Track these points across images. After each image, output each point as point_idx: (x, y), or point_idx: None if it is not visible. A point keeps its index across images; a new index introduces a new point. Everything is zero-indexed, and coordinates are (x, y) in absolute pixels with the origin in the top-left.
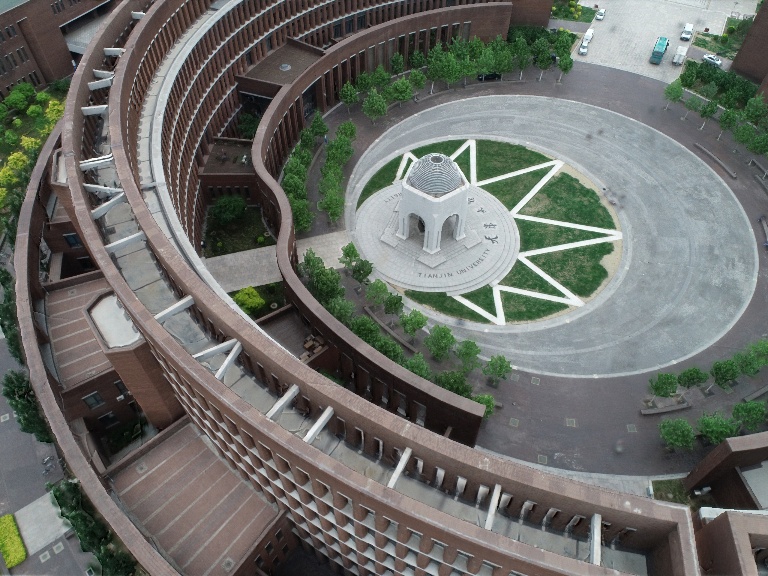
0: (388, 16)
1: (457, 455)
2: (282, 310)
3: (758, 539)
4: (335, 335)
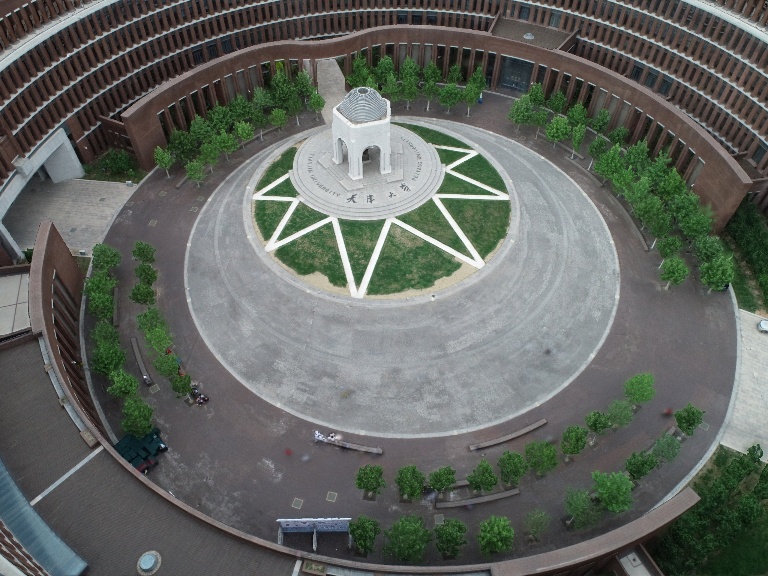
0: (695, 107)
1: None
2: None
3: None
4: None
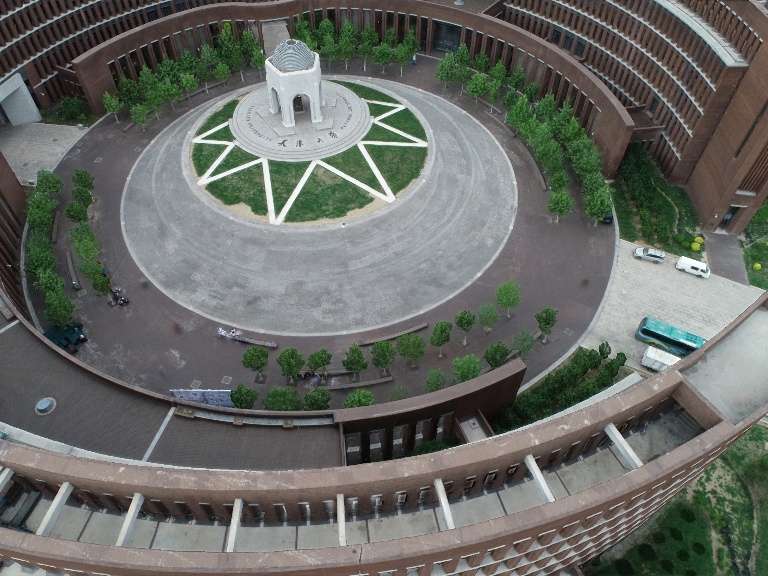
0: (605, 66)
1: None
2: None
3: None
4: None
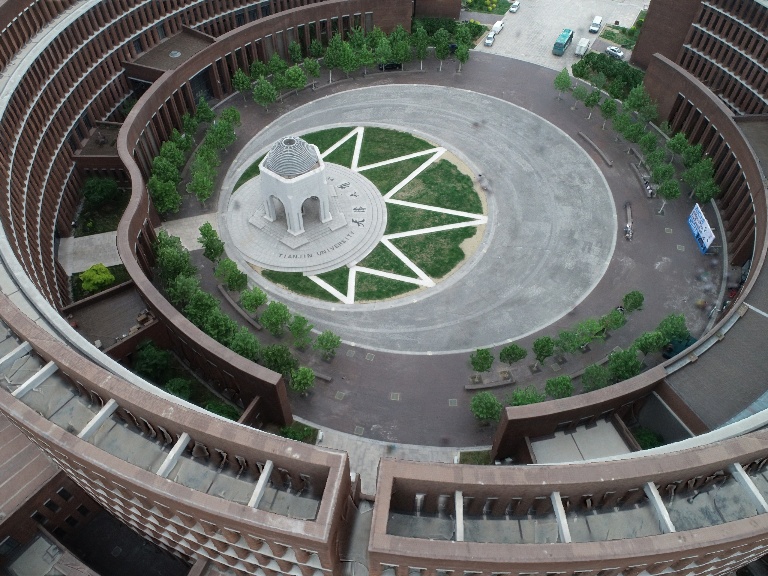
0: (294, 6)
1: (145, 404)
2: (122, 285)
3: (409, 484)
4: (154, 307)
